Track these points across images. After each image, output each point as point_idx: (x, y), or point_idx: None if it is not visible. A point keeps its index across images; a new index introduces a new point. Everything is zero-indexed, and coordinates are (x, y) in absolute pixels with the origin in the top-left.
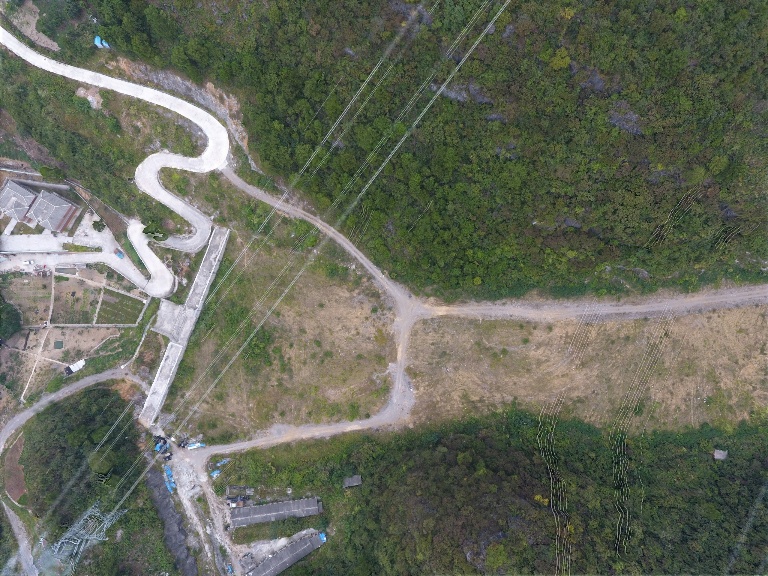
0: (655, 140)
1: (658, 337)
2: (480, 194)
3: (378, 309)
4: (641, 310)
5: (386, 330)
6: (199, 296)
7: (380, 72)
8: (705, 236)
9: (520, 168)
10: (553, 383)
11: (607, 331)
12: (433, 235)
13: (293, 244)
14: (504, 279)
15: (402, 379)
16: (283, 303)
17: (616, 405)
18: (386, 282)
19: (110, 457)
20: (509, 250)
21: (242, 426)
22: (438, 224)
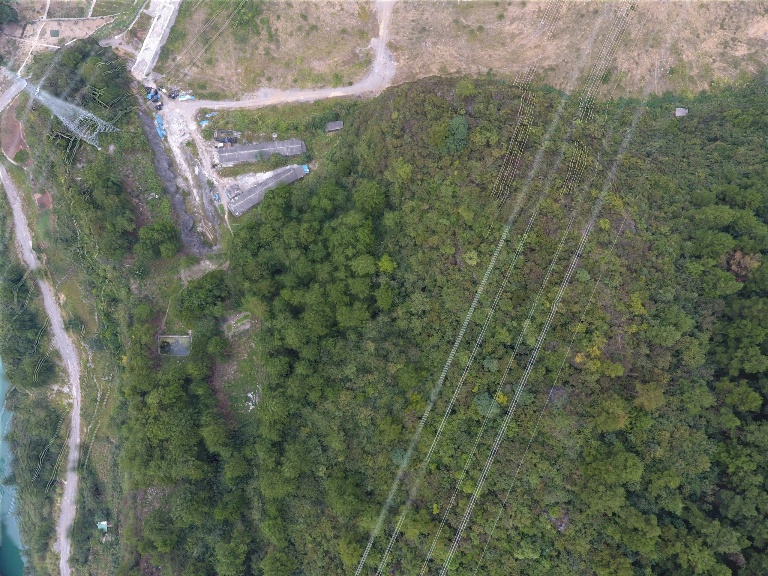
0: None
1: (625, 10)
2: None
3: None
4: None
5: (369, 8)
6: None
7: None
8: None
9: None
10: (526, 55)
11: (577, 6)
12: None
13: None
14: None
15: (383, 53)
16: None
17: (585, 73)
18: None
19: (104, 78)
20: None
21: (230, 89)
22: None
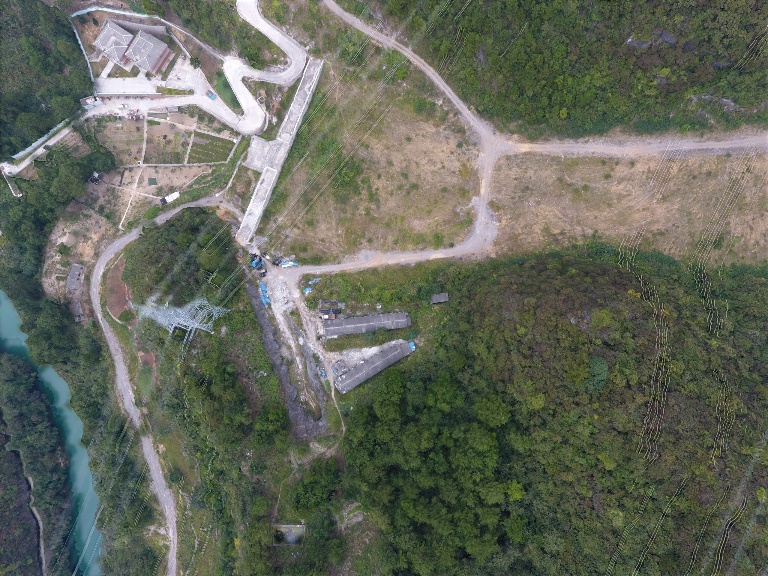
0: None
1: (740, 172)
2: (577, 11)
3: (463, 144)
4: (724, 146)
5: (470, 165)
6: (294, 124)
7: None
8: None
9: None
10: (634, 217)
11: (689, 167)
12: (525, 59)
13: (384, 77)
14: (589, 114)
15: (485, 212)
16: (372, 136)
17: (696, 238)
18: (472, 118)
19: None
20: (599, 77)
21: (331, 251)
22: (531, 48)
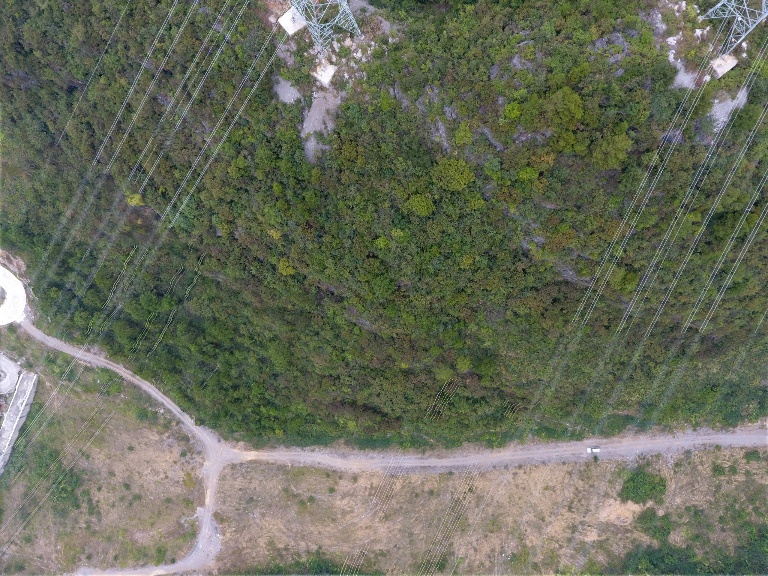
0: (394, 342)
1: (462, 492)
2: (259, 362)
3: (187, 453)
4: (446, 464)
5: (195, 474)
6: (6, 441)
7: (137, 254)
8: (482, 413)
9: (283, 349)
10: (357, 534)
11: (412, 484)
12: (224, 394)
13: (100, 389)
14: None
15: (209, 524)
16: (93, 445)
17: (418, 560)
18: (195, 426)
19: None
20: None
21: (49, 568)
22: (228, 384)
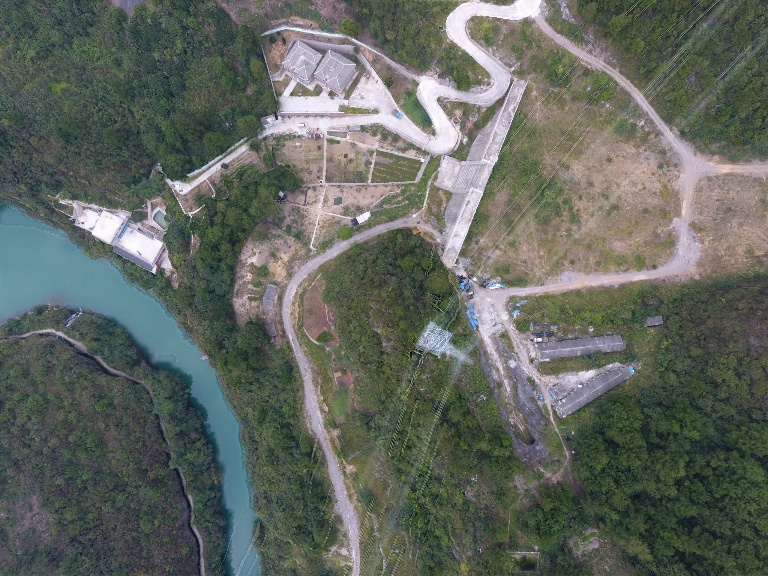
0: None
1: None
2: None
3: (664, 165)
4: None
5: (671, 186)
6: (498, 145)
7: None
8: None
9: None
10: None
11: None
12: (745, 82)
13: (588, 98)
14: None
15: (687, 233)
16: (572, 157)
17: None
18: (673, 139)
19: None
20: None
21: (534, 272)
22: (752, 71)
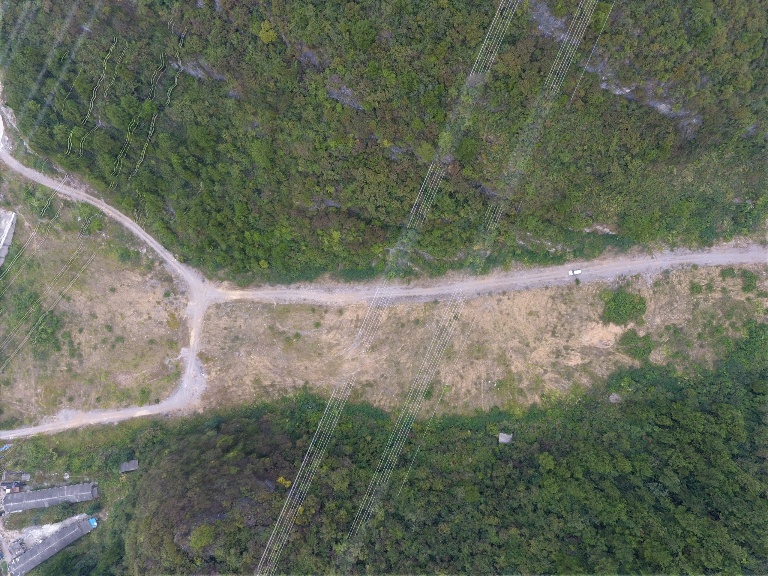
0: (376, 115)
1: (447, 320)
2: (242, 174)
3: (171, 293)
4: (431, 293)
5: (179, 315)
6: None
7: (117, 49)
8: (464, 215)
9: (266, 147)
10: (344, 367)
11: (397, 314)
12: (207, 217)
13: (80, 228)
14: (294, 262)
15: (194, 364)
16: (74, 288)
17: (405, 389)
18: (178, 266)
19: None
20: (287, 232)
21: (29, 412)
22: (211, 206)
